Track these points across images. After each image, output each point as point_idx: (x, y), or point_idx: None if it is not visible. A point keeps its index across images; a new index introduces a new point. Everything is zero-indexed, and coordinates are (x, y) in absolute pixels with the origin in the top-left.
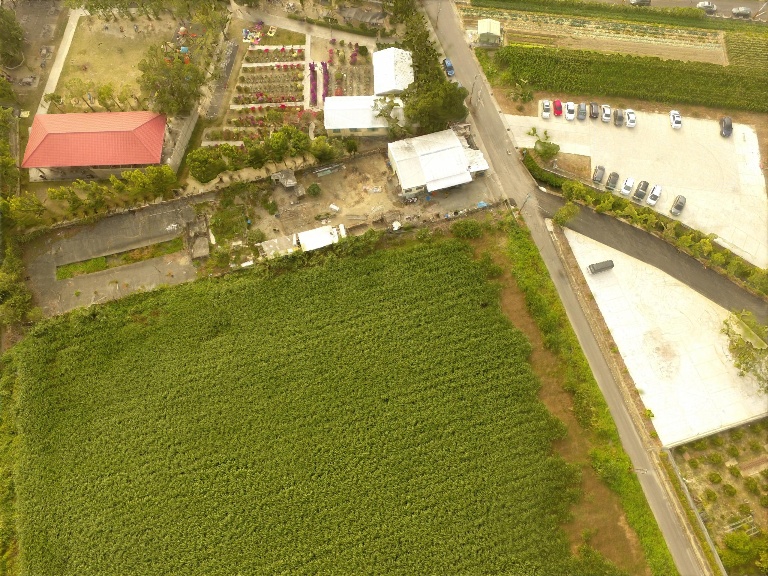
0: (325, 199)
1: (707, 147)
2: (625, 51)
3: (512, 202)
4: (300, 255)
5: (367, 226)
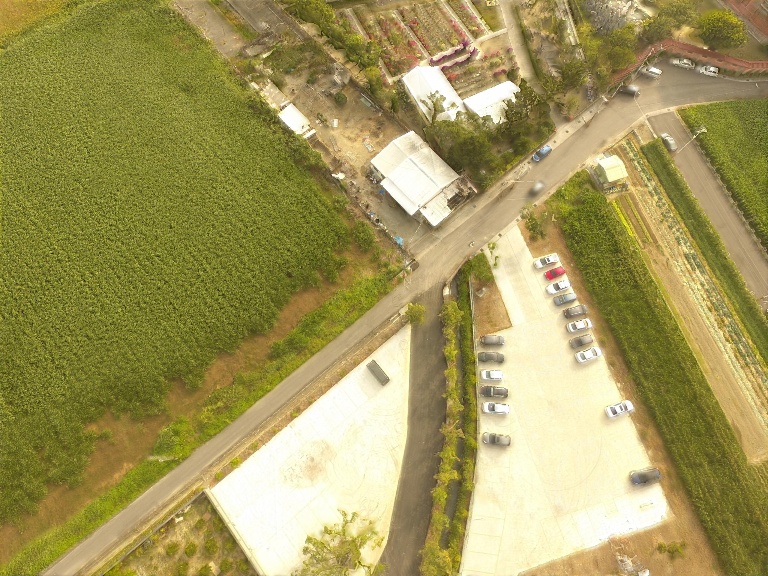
0: (341, 113)
1: (602, 458)
2: (688, 325)
3: (415, 266)
4: (273, 113)
5: (329, 154)
